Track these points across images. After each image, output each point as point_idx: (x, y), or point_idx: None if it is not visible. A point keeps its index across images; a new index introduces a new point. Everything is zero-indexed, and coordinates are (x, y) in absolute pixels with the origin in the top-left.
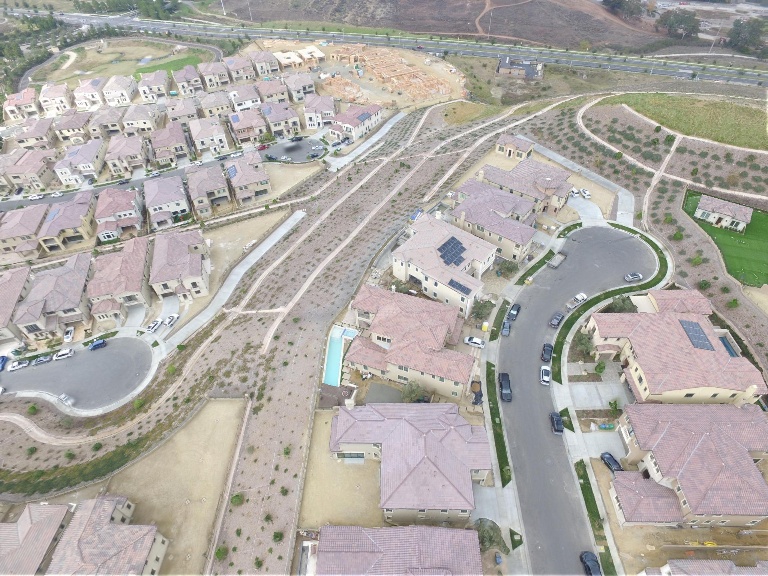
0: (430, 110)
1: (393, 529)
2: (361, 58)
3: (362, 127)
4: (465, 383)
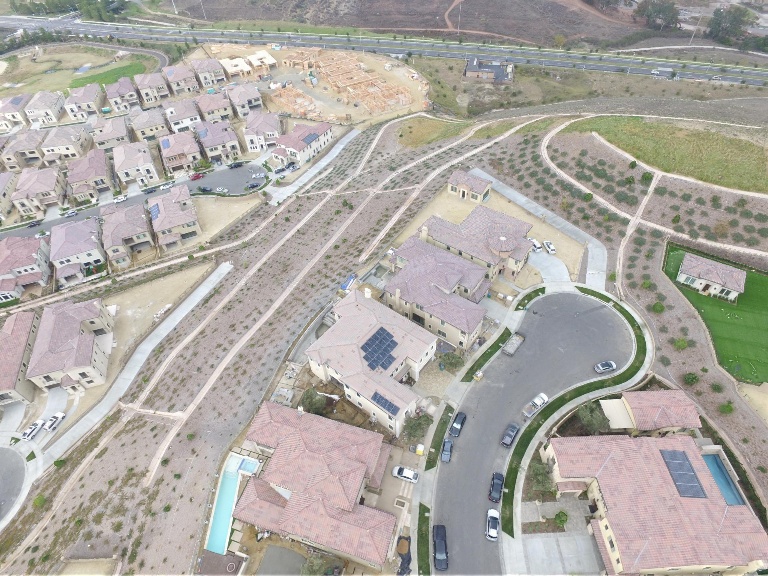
0: (385, 128)
1: None
2: (316, 64)
3: (309, 150)
4: (380, 564)
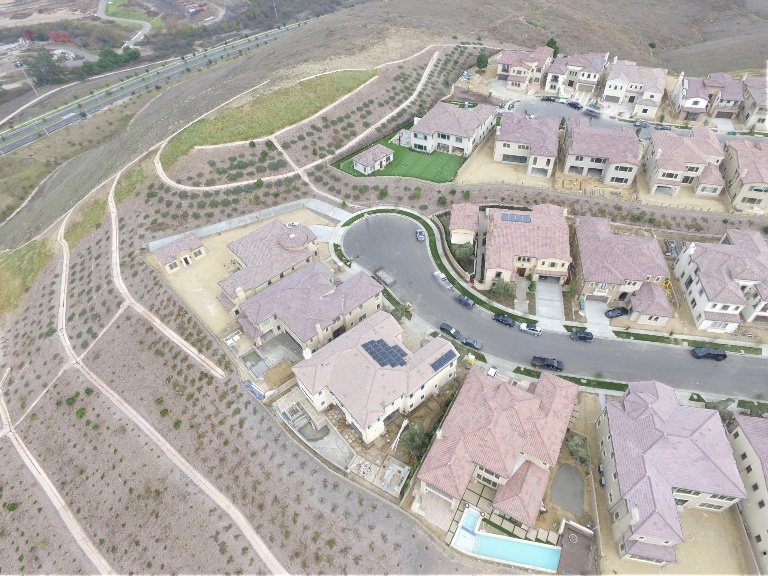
0: None
1: None
2: None
3: None
4: None
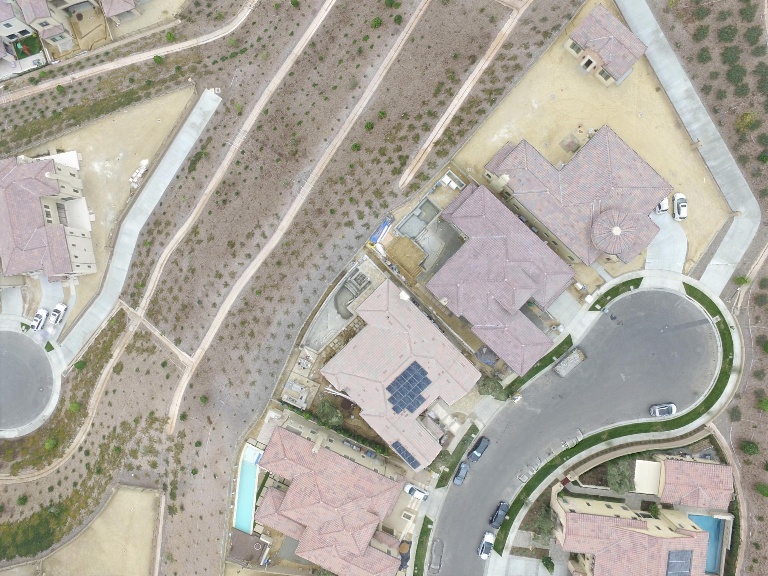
0: None
1: None
2: None
3: None
4: None
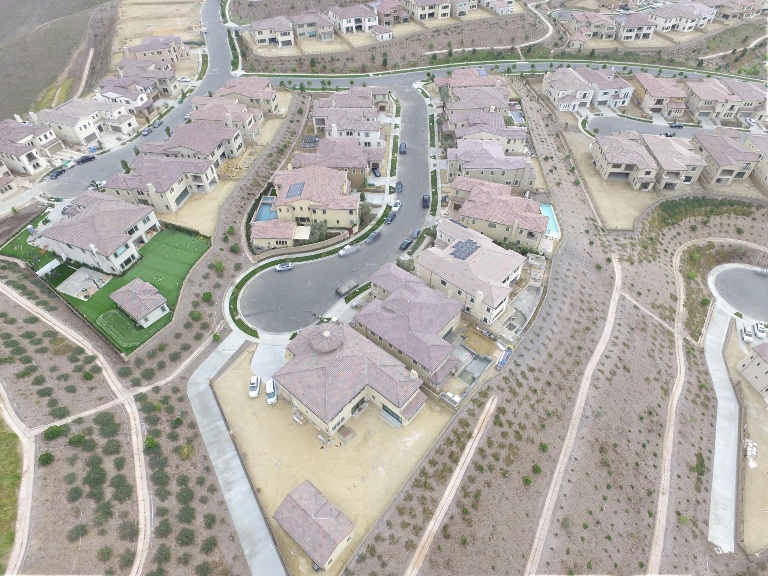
0: None
1: (494, 133)
2: None
3: None
4: None
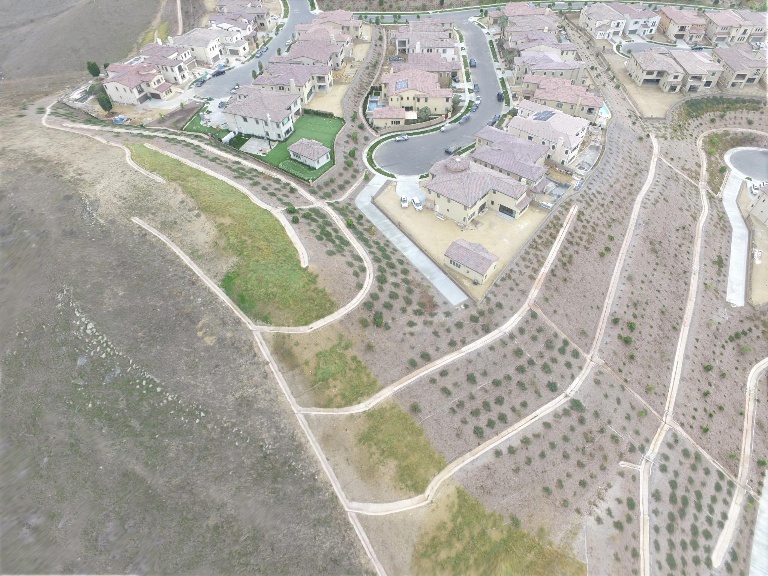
0: None
1: None
2: None
3: None
4: None
